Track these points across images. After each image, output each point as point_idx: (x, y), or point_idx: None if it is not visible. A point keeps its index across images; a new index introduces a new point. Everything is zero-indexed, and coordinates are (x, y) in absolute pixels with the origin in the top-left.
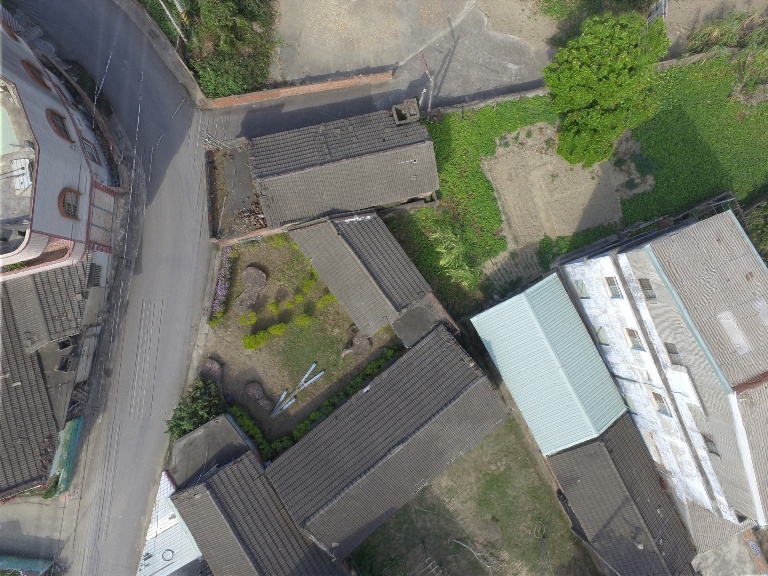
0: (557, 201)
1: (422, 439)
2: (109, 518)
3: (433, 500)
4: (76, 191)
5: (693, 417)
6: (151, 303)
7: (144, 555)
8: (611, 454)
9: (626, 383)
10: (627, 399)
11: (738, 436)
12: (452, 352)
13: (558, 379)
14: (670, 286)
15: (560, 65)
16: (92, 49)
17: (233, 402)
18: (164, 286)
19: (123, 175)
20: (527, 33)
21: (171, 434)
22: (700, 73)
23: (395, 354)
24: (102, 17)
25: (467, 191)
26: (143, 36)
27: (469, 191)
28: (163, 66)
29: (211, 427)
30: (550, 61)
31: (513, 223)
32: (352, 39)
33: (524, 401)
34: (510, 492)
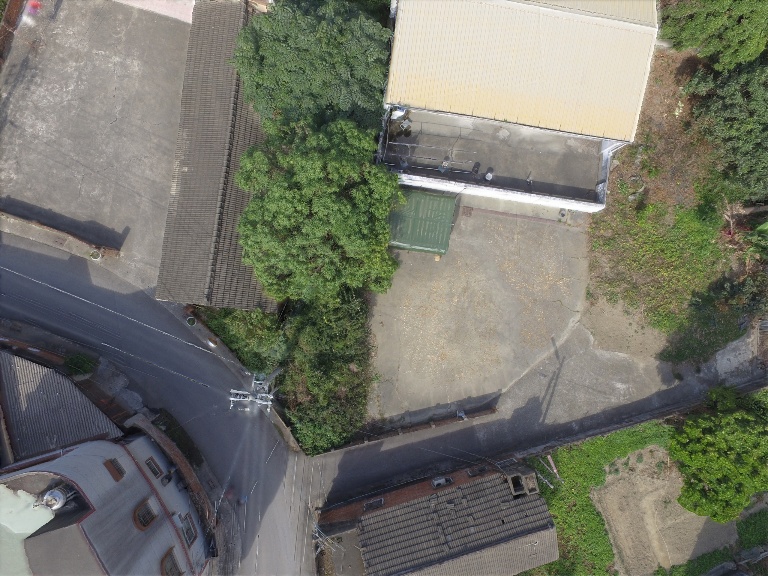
0: (670, 528)
1: None
2: None
3: None
4: None
5: None
6: None
7: None
8: None
9: None
10: None
11: None
12: None
13: None
14: None
15: (690, 440)
16: (180, 395)
17: None
18: None
19: (220, 540)
20: (635, 349)
21: None
22: None
23: None
24: (190, 359)
25: (577, 526)
26: (233, 376)
27: (579, 526)
28: (254, 407)
29: None
30: (659, 377)
31: (625, 555)
32: (452, 369)
33: None
34: None
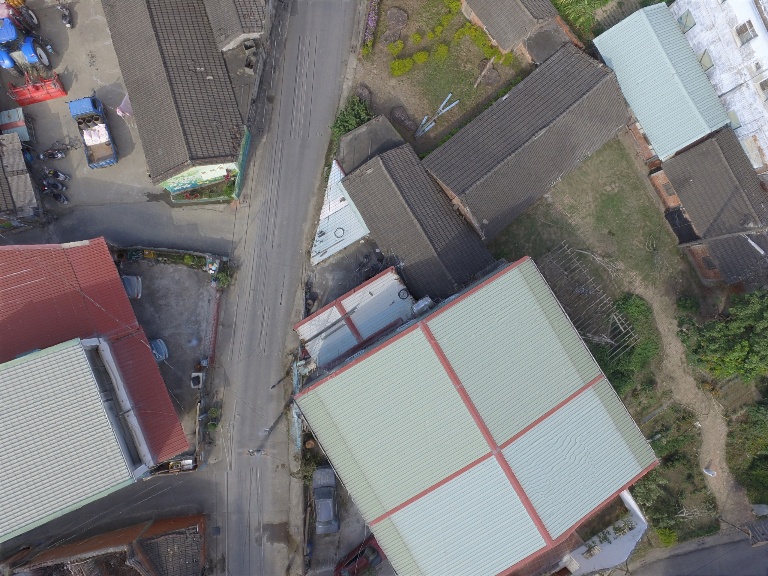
0: None
1: (560, 128)
2: (275, 224)
3: (557, 215)
4: None
5: None
6: (306, 40)
7: (318, 233)
8: (722, 149)
9: (730, 96)
10: None
11: None
12: (581, 60)
13: (673, 85)
14: None
15: None
16: None
17: None
18: (317, 26)
19: None
20: None
21: (339, 131)
22: None
23: None
24: None
25: None
26: None
27: None
28: None
29: (373, 125)
30: None
31: None
32: None
33: (642, 110)
34: (624, 210)
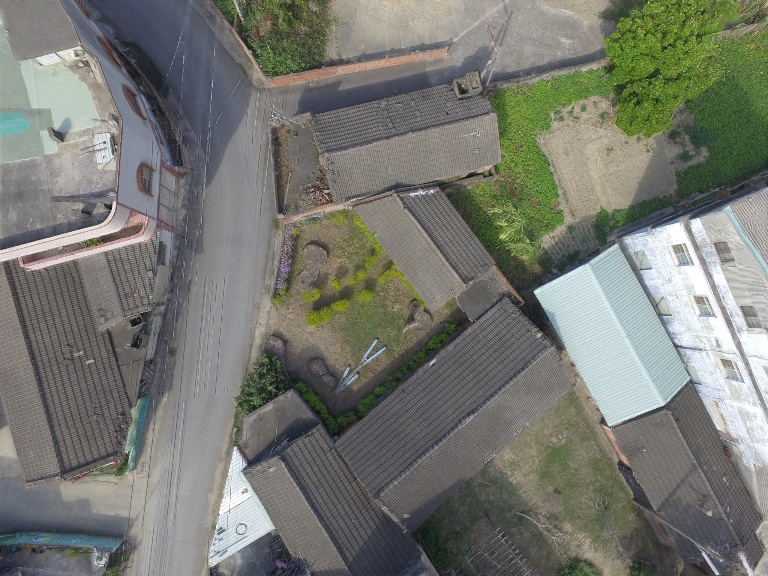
0: (612, 174)
1: (492, 410)
2: (177, 495)
3: (496, 473)
4: (150, 167)
5: None
6: (213, 282)
7: (218, 529)
8: (678, 422)
9: (689, 352)
10: (689, 369)
11: None
12: (518, 324)
13: (623, 349)
14: (752, 247)
15: (622, 35)
16: (149, 30)
17: (297, 379)
18: (226, 265)
19: (184, 155)
20: (579, 7)
21: (241, 409)
22: (752, 44)
23: (457, 328)
24: None
25: (523, 166)
26: (199, 17)
27: (525, 166)
28: (219, 46)
29: (281, 402)
30: (603, 35)
31: (569, 197)
32: (406, 16)
33: (589, 372)
34: (572, 464)
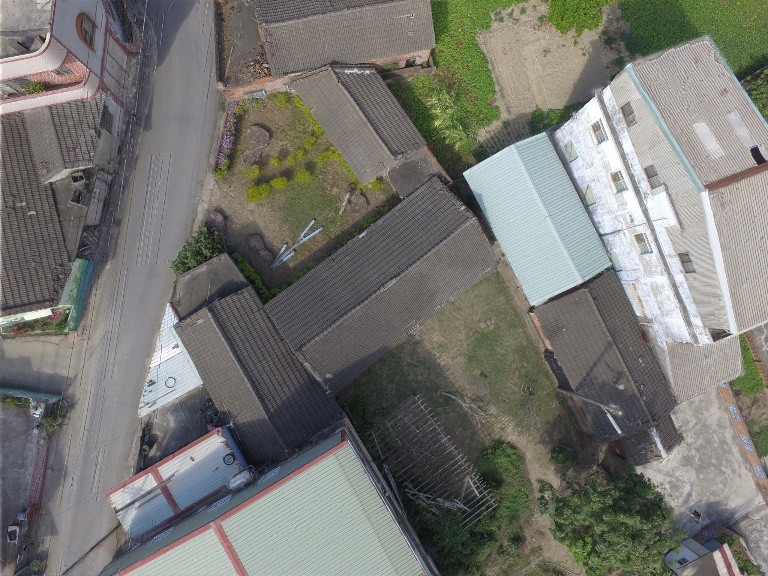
0: (549, 75)
1: (414, 277)
2: (115, 359)
3: (424, 354)
4: (93, 22)
5: (671, 241)
6: (159, 158)
7: (148, 382)
8: (595, 300)
9: (611, 238)
10: (612, 258)
11: (710, 233)
12: (444, 199)
13: (545, 228)
14: (649, 99)
15: None
16: None
17: None
18: (172, 143)
19: (136, 33)
20: None
21: (176, 269)
22: None
23: None
24: None
25: (463, 62)
26: None
27: (465, 62)
28: None
29: (214, 264)
30: None
31: (506, 94)
32: None
33: (513, 252)
34: (499, 350)
